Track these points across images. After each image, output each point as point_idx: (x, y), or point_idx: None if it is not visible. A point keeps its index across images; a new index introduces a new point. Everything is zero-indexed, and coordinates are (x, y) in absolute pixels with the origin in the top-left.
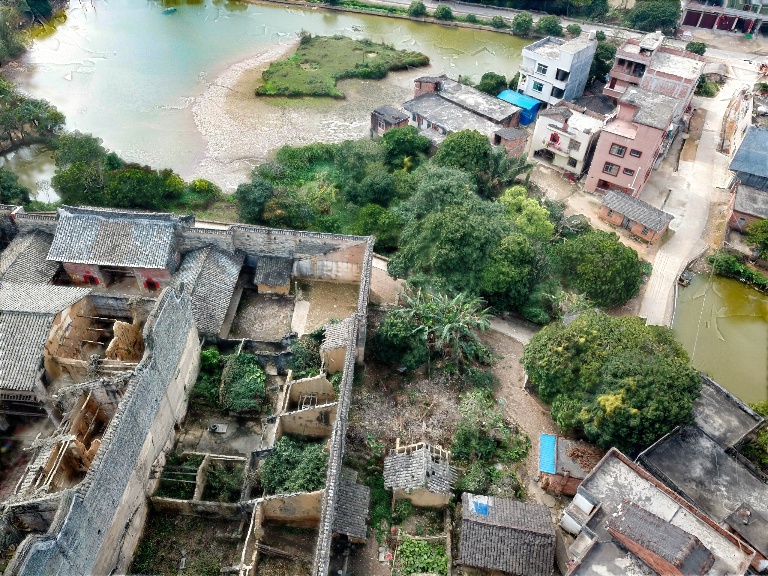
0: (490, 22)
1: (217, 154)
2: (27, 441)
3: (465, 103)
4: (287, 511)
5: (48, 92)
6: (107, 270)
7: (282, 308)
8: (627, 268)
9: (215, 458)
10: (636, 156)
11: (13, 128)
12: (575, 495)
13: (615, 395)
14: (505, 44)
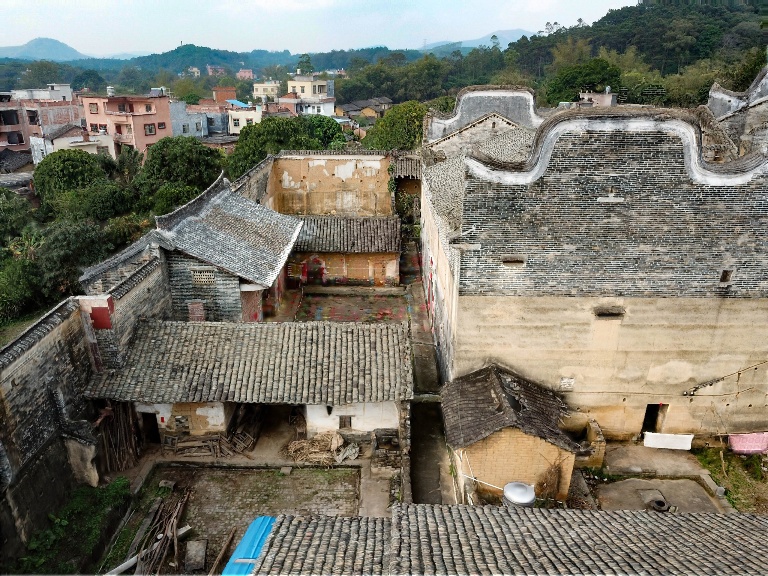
0: None
1: None
2: None
3: None
4: None
5: None
6: (262, 292)
7: None
8: None
9: None
10: (162, 128)
11: None
12: None
13: None
14: None
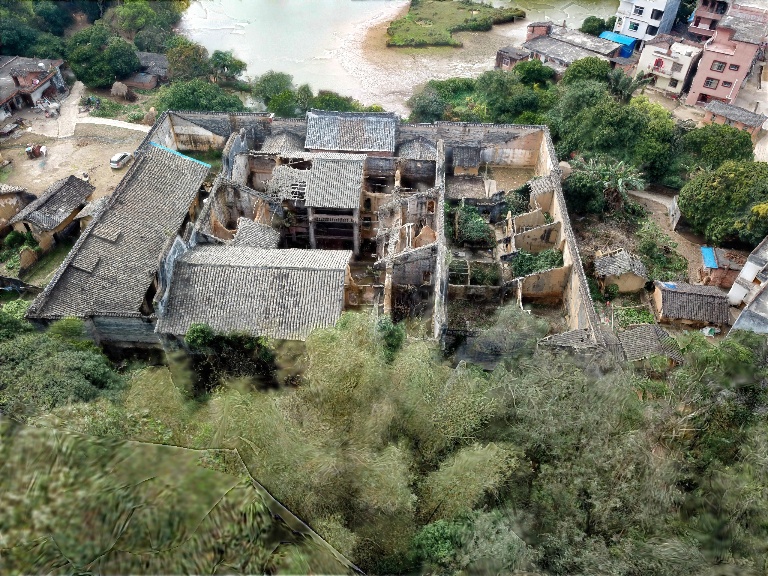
0: None
1: (372, 90)
2: None
3: (574, 42)
4: (538, 287)
5: None
6: None
7: (475, 185)
8: (743, 145)
9: (475, 261)
10: (734, 70)
11: (211, 73)
12: (740, 272)
13: (765, 203)
14: (584, 1)
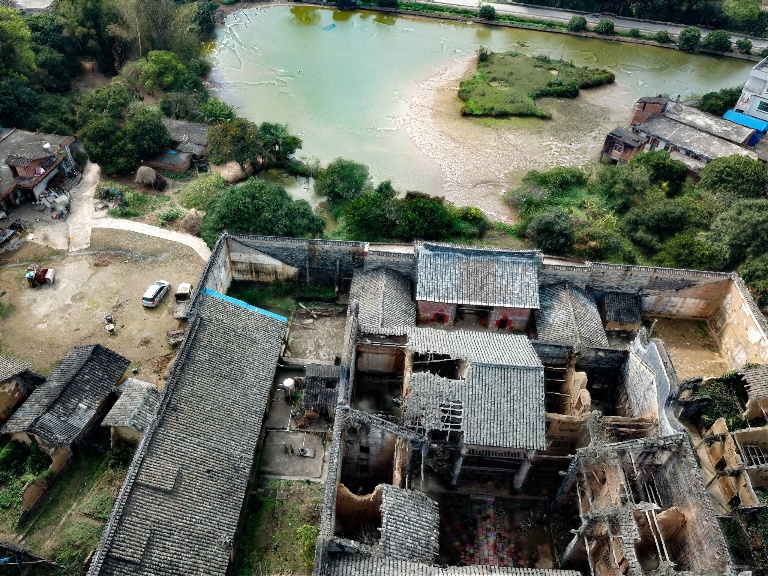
0: (654, 37)
1: (456, 178)
2: (474, 495)
3: (696, 124)
4: None
5: (255, 113)
6: (464, 308)
7: None
8: None
9: None
10: None
11: (260, 154)
12: None
13: None
14: (668, 59)
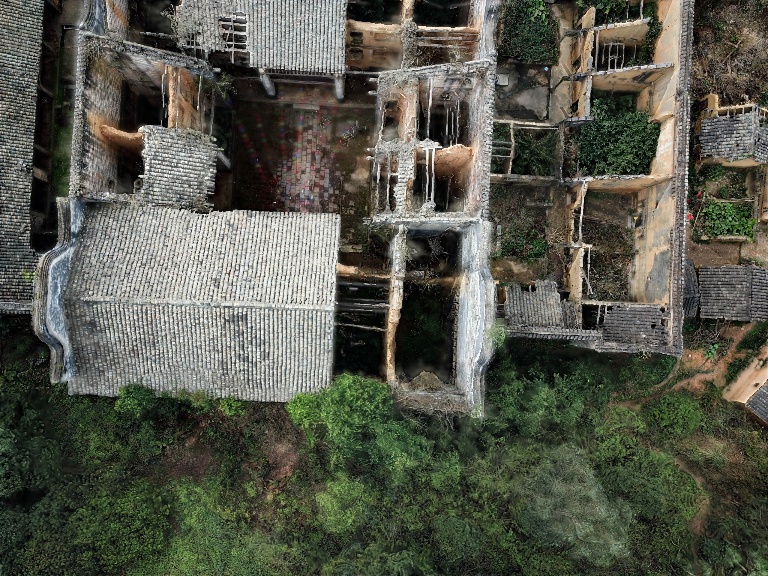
0: None
1: None
2: (298, 104)
3: None
4: (609, 185)
5: None
6: None
7: None
8: None
9: (523, 127)
10: None
11: None
12: None
13: None
14: None
